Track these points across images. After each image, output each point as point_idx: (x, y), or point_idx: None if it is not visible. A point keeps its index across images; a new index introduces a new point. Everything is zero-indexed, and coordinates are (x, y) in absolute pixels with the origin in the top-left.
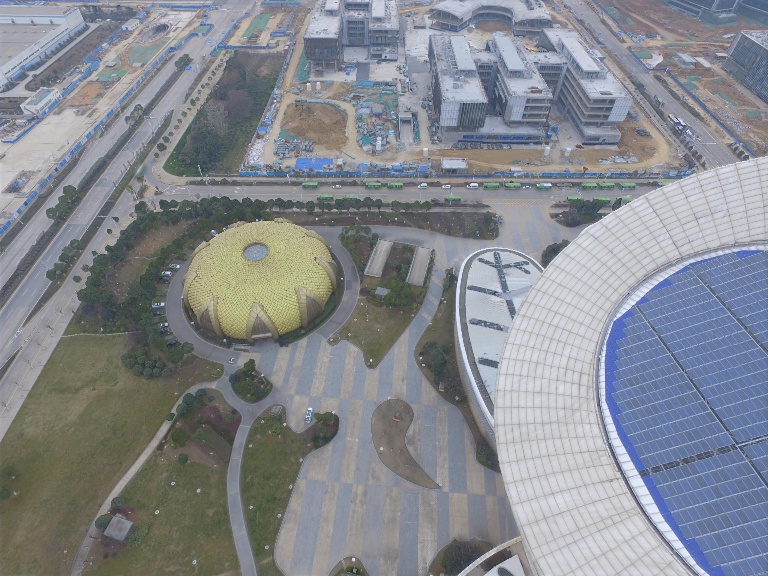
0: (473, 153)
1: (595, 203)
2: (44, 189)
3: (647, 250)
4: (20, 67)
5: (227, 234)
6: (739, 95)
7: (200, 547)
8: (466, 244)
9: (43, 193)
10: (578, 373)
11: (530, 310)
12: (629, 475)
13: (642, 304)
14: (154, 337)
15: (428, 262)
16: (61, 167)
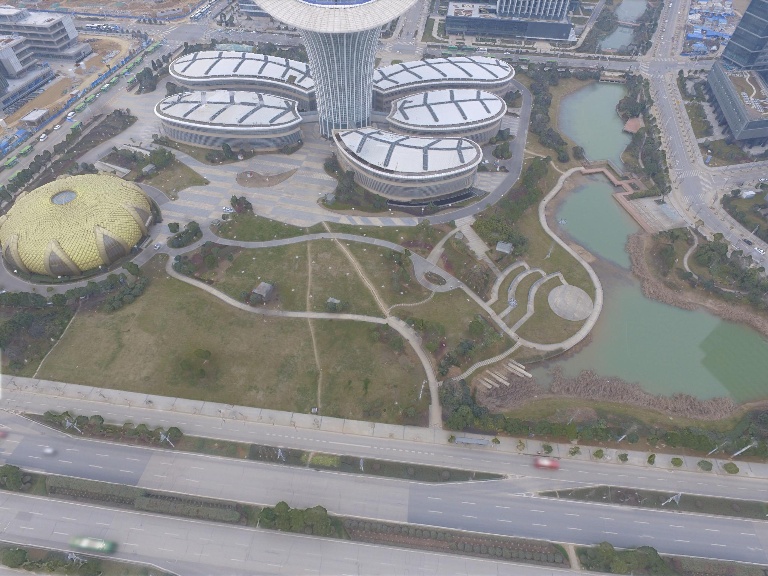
0: (28, 107)
1: (147, 70)
2: None
3: None
4: None
5: (15, 221)
6: (95, 1)
7: (289, 256)
8: (132, 131)
9: None
10: (297, 4)
11: (265, 5)
12: (335, 7)
13: None
14: (103, 281)
15: (135, 147)
16: None
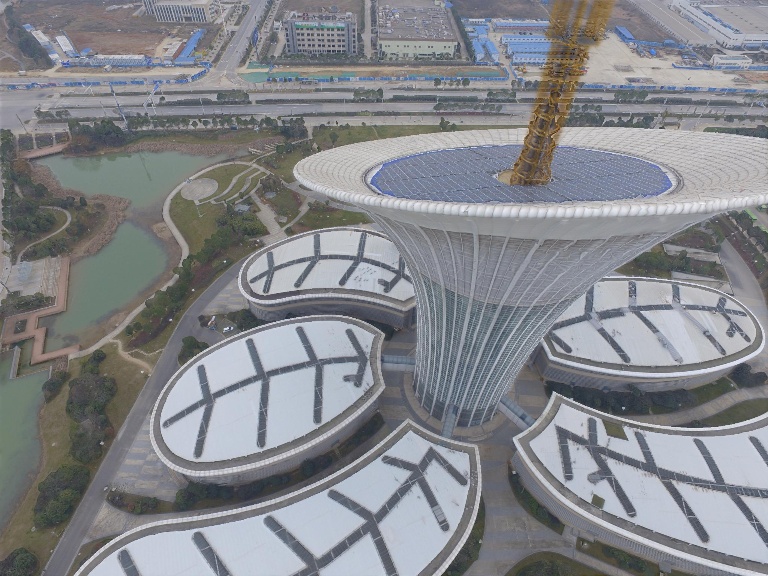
0: None
1: None
2: (640, 89)
3: (639, 145)
4: (763, 43)
5: None
6: None
7: None
8: (765, 325)
9: (636, 90)
10: None
11: (566, 128)
12: None
13: (587, 150)
14: None
15: None
16: (667, 89)
